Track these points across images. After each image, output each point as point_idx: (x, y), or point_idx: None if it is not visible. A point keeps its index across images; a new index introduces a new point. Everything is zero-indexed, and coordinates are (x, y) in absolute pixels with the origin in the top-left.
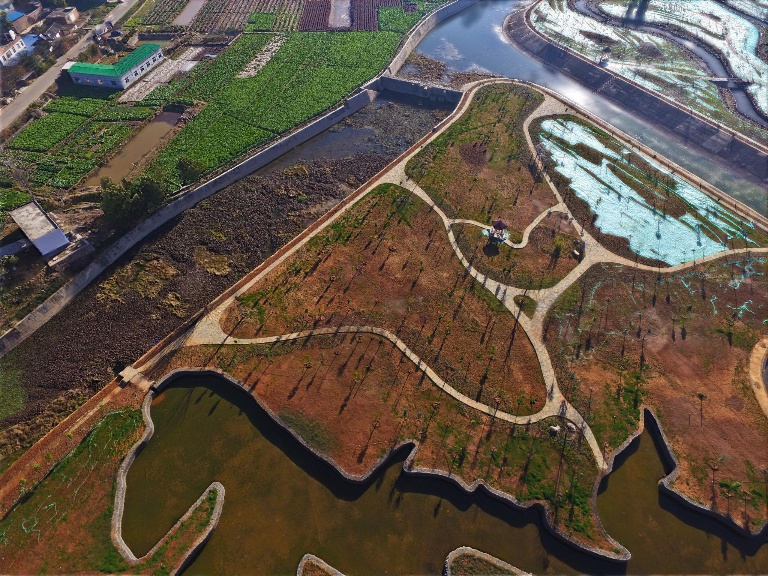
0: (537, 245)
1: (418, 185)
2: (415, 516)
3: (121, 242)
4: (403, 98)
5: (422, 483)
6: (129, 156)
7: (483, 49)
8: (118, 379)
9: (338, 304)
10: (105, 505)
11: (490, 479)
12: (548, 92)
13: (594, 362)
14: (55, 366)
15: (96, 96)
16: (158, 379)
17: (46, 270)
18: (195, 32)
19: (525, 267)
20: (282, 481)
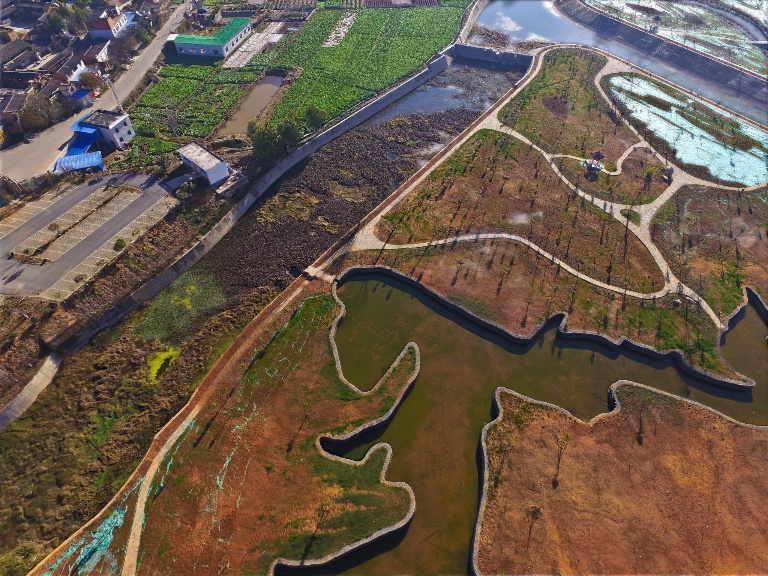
0: (630, 172)
1: (514, 129)
2: (576, 363)
3: (266, 178)
4: (477, 63)
5: (574, 343)
6: (248, 112)
7: (538, 21)
8: (304, 275)
9: (472, 219)
10: (327, 358)
11: (632, 336)
12: (610, 55)
13: (698, 256)
14: (241, 270)
15: (202, 63)
16: (338, 274)
17: (215, 197)
18: (272, 9)
19: (624, 189)
20: (462, 342)
